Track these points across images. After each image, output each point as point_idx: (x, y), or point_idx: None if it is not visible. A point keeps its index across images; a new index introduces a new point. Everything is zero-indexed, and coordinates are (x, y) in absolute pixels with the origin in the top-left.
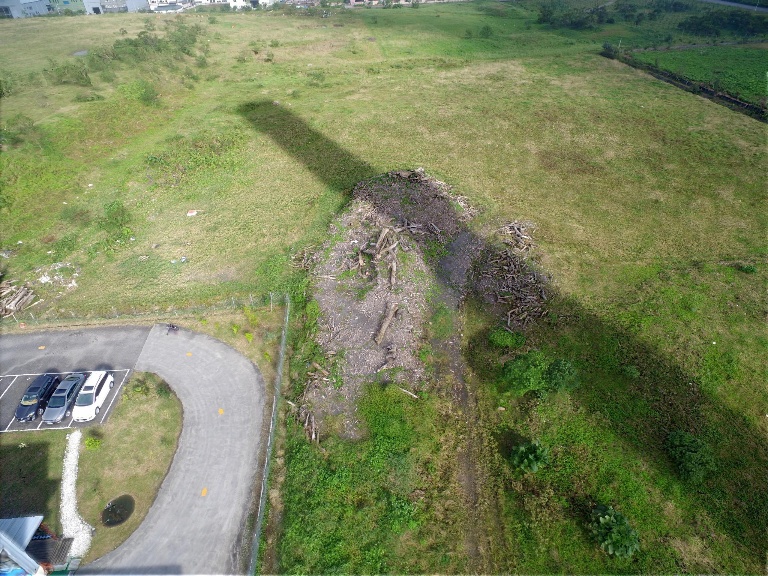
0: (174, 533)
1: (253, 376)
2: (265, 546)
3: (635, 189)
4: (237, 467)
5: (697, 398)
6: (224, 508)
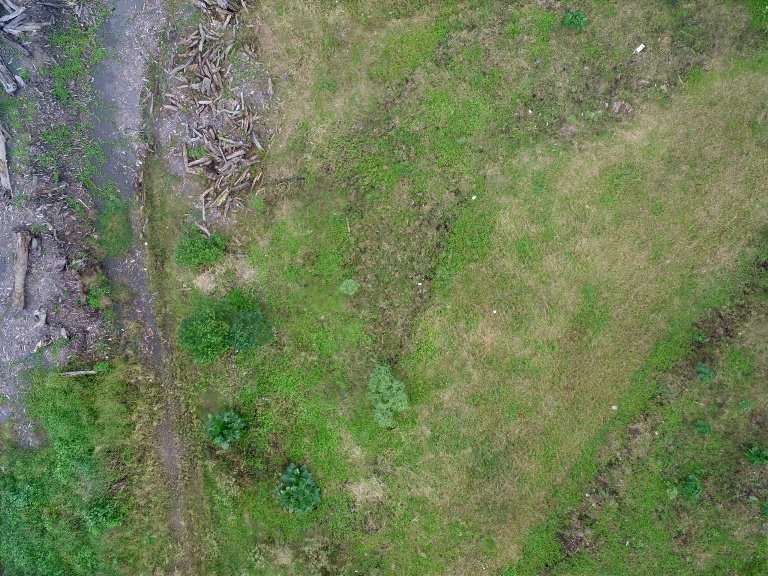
0: None
1: None
2: None
3: None
4: None
5: (424, 302)
6: None
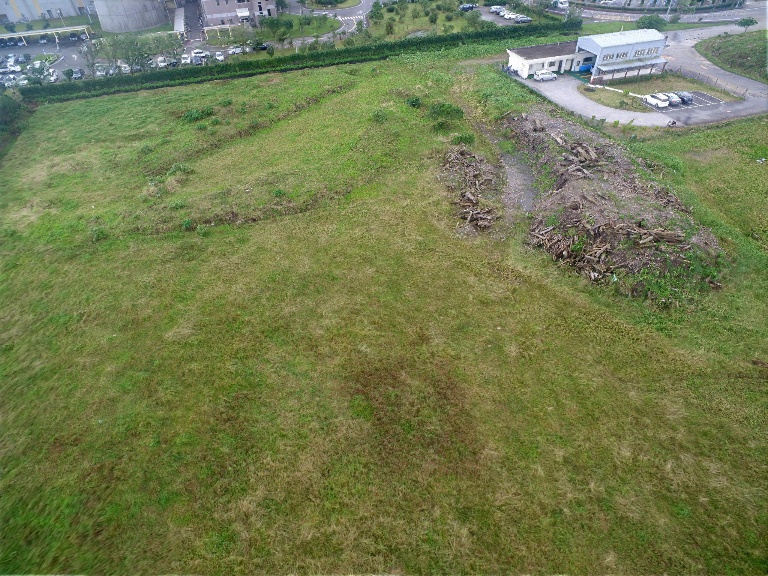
0: None
1: None
2: None
3: (313, 324)
4: None
5: None
6: None
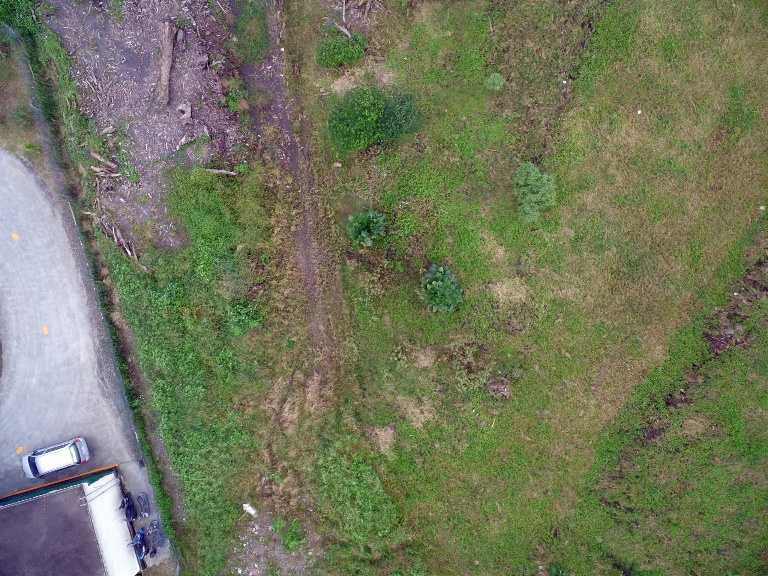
0: (37, 373)
1: (29, 179)
2: (125, 367)
3: None
4: (65, 298)
5: (567, 102)
6: (72, 341)
